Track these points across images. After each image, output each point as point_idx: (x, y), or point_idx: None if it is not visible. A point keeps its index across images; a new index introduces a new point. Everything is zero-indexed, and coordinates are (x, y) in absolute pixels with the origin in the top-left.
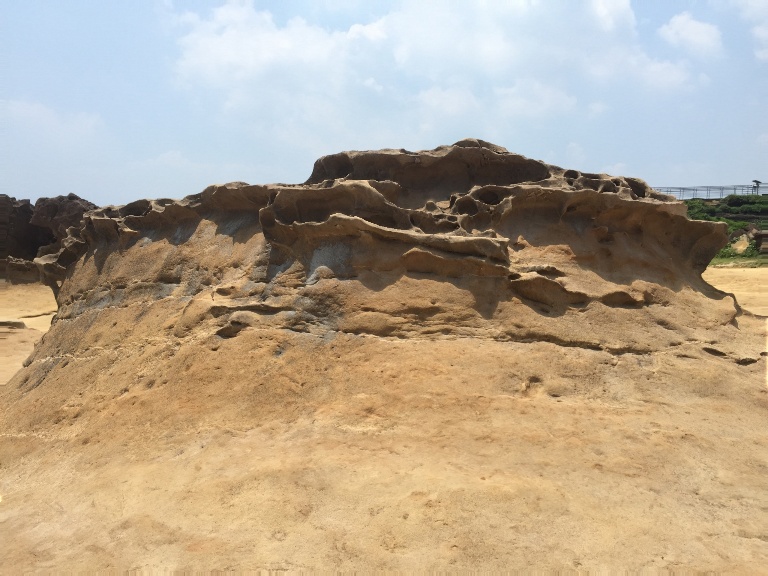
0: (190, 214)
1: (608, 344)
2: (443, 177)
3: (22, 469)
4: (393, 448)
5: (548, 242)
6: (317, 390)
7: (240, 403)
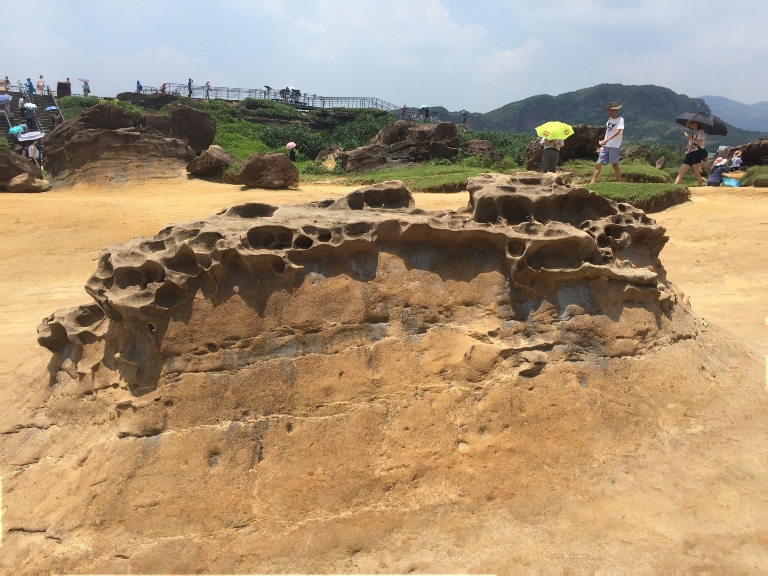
0: (365, 247)
1: (692, 333)
2: (544, 206)
3: (423, 543)
4: (733, 438)
5: (642, 264)
6: (642, 408)
7: (604, 431)
